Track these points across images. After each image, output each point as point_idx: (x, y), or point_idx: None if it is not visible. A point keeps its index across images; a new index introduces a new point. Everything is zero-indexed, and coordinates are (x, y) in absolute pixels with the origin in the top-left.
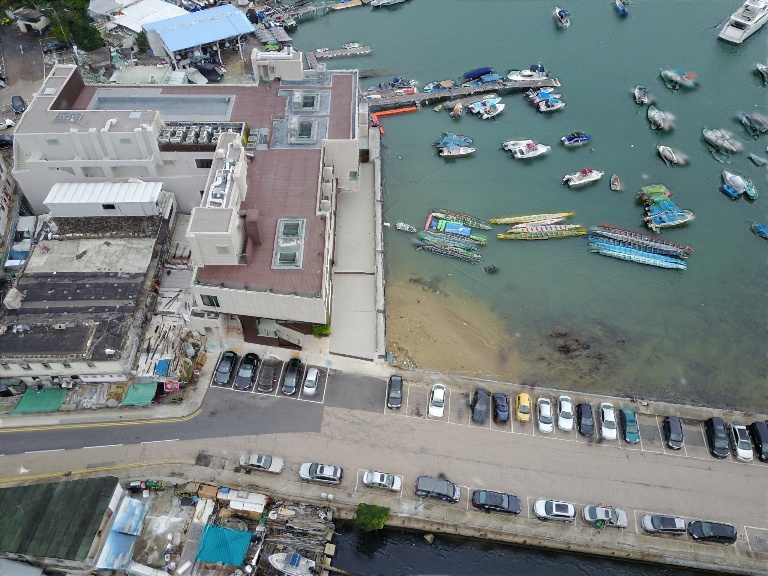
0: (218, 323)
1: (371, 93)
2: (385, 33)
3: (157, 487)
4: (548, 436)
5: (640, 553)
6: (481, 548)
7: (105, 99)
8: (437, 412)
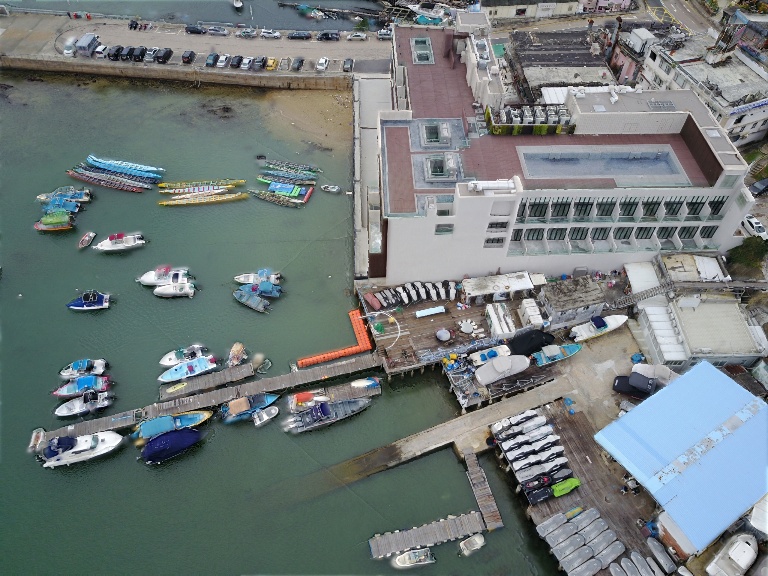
0: None
1: None
2: None
3: None
4: None
5: None
6: None
7: None
8: None
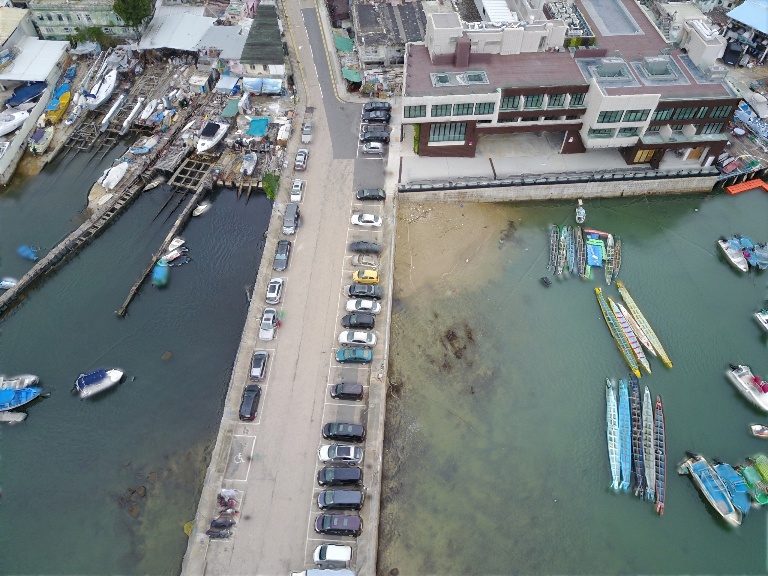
0: None
1: None
2: None
3: None
4: (341, 295)
5: None
6: None
7: None
8: (354, 218)
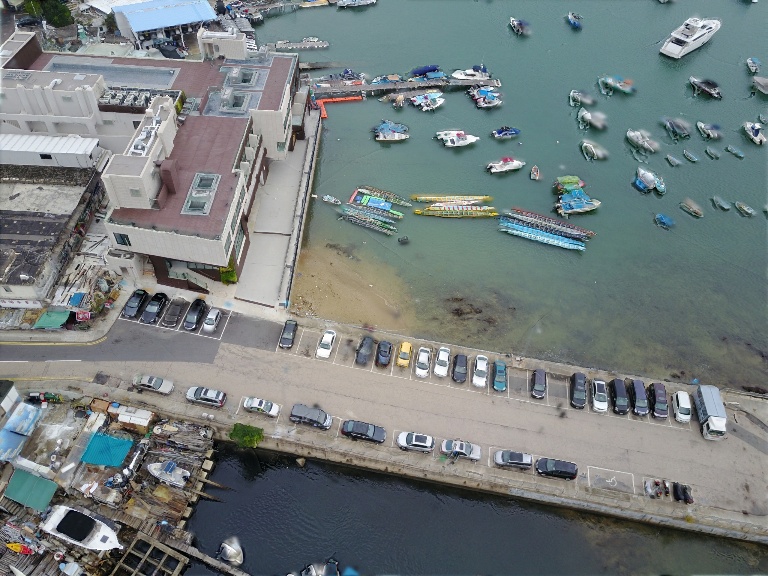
0: (132, 263)
1: (321, 82)
2: (346, 31)
3: (55, 400)
4: (423, 381)
5: (488, 482)
6: (348, 474)
7: (59, 65)
8: (324, 353)
